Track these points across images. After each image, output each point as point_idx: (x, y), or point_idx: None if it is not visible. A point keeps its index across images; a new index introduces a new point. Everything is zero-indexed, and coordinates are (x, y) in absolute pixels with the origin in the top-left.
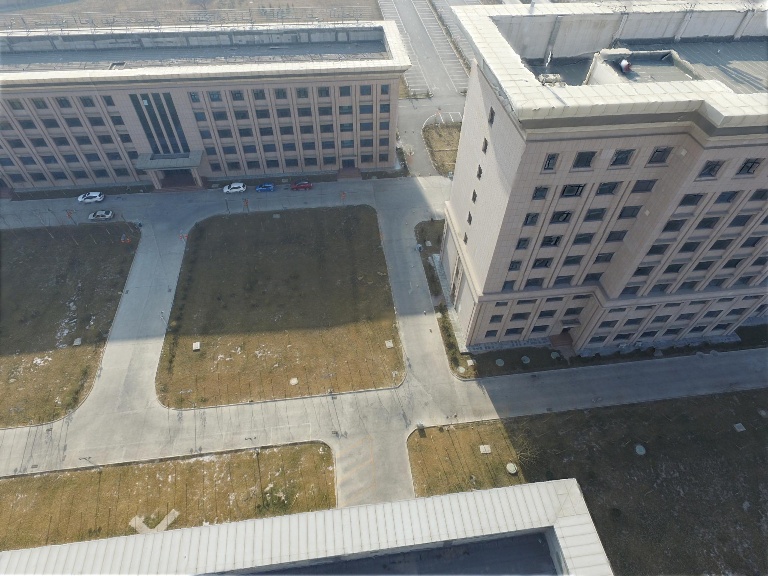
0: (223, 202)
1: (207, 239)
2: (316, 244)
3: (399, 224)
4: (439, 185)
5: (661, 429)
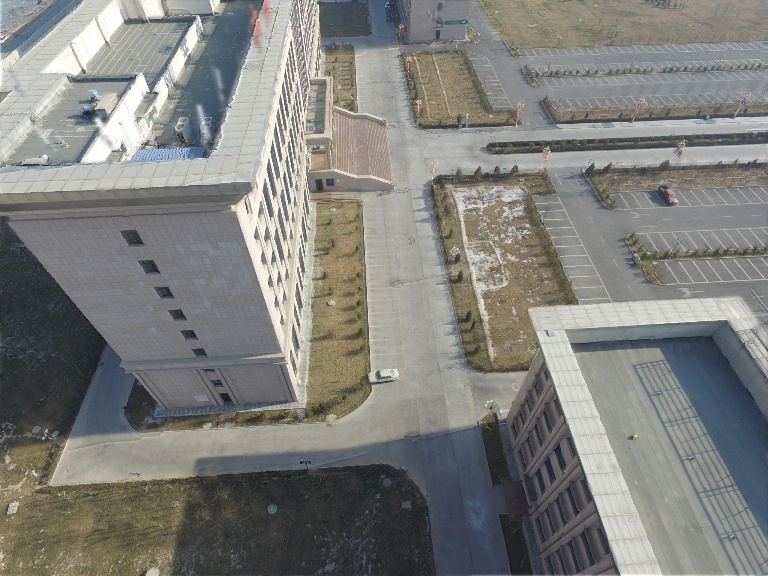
0: (378, 5)
1: (350, 4)
2: (342, 24)
3: (353, 41)
4: (389, 53)
5: None
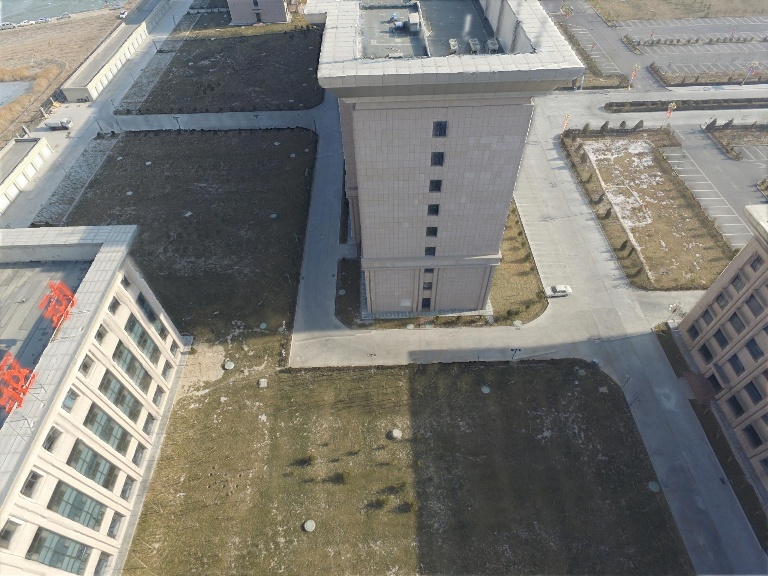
0: None
1: None
2: None
3: None
4: None
5: (317, 53)
